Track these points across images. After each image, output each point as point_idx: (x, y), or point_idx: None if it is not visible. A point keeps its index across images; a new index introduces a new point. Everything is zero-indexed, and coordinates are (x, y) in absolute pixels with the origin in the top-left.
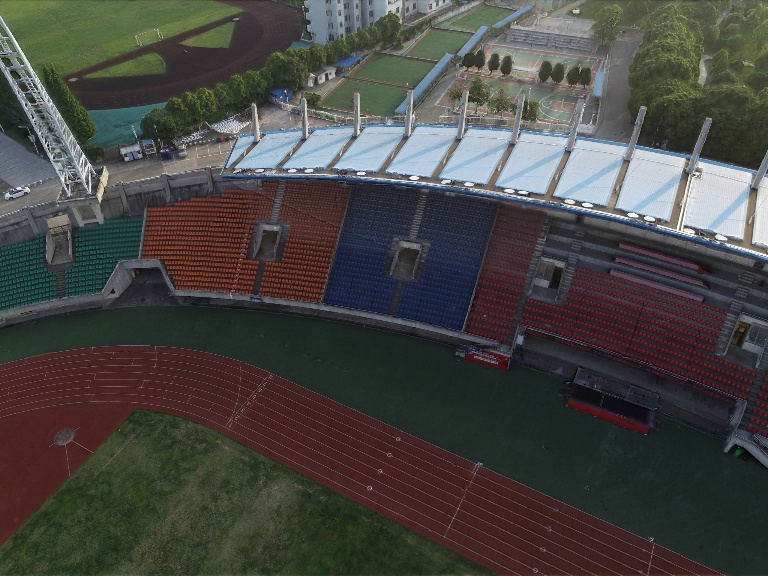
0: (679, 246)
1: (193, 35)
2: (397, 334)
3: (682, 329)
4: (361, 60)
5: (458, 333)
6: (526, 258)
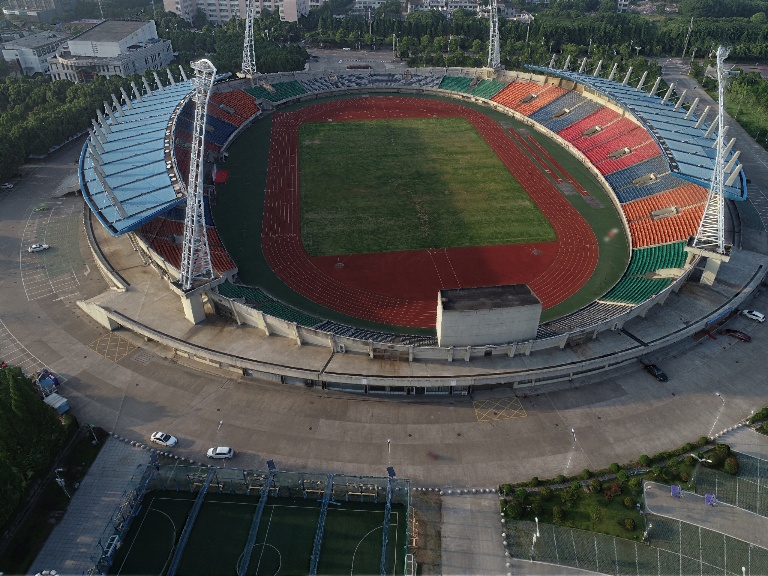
0: None
1: None
2: None
3: None
4: None
5: None
6: None
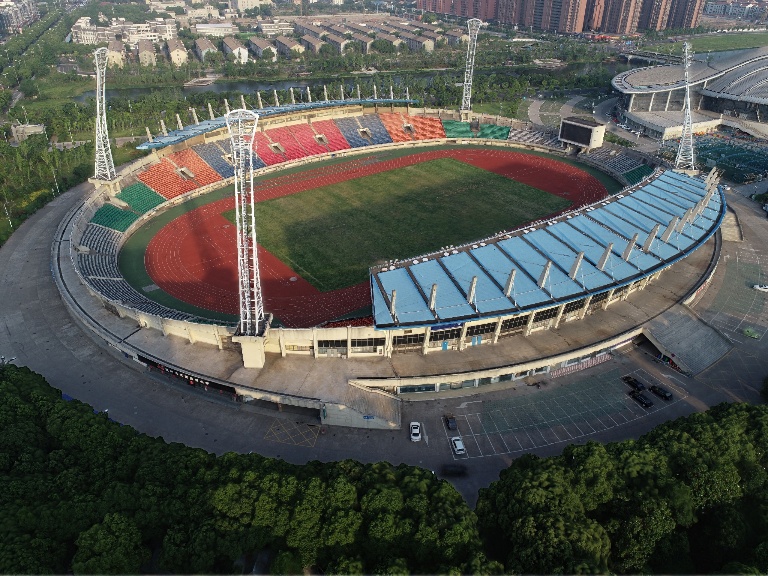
0: None
1: None
2: None
3: None
4: None
5: None
6: None
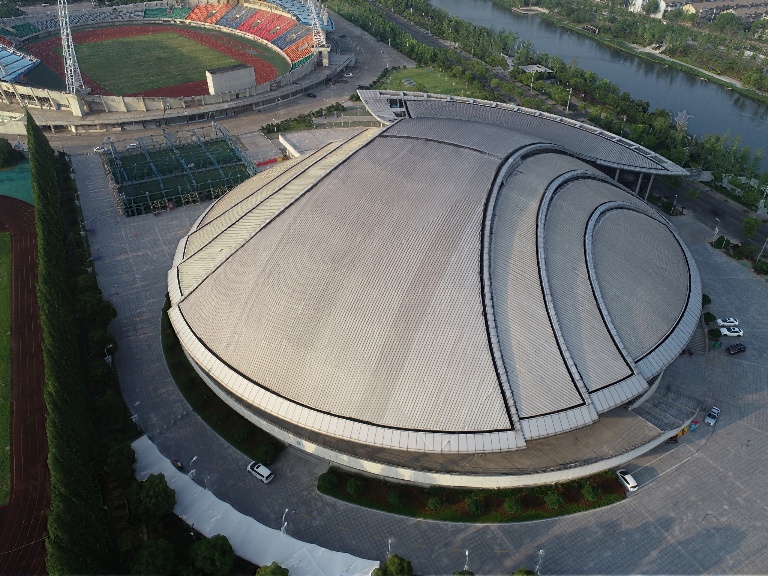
0: None
1: None
2: None
3: None
4: None
5: None
6: None
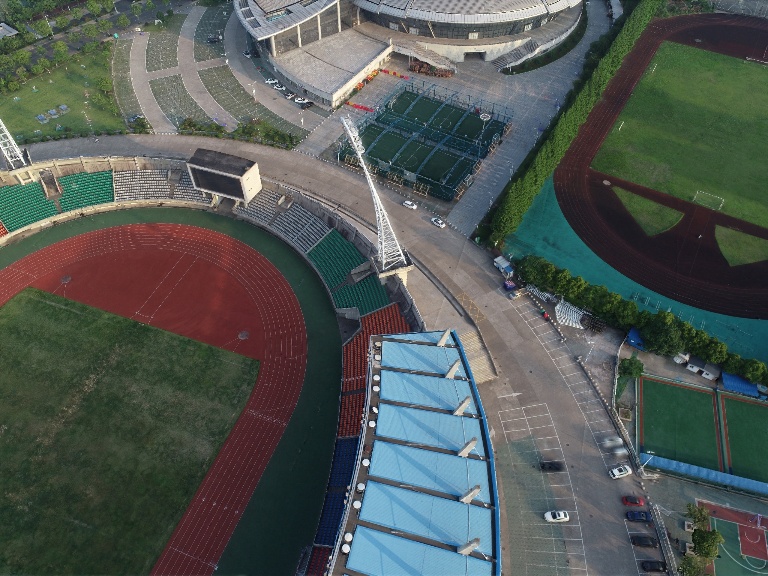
0: None
1: (742, 229)
2: None
3: None
4: (764, 399)
5: None
6: None
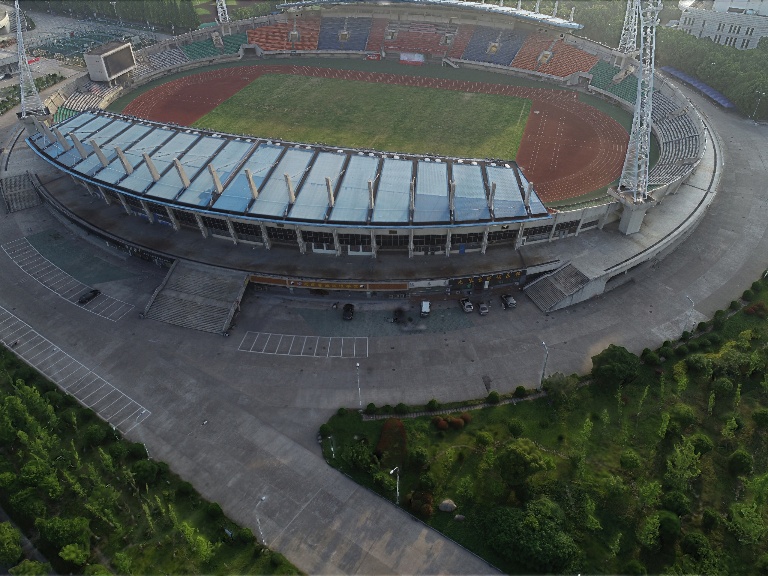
0: (429, 21)
1: None
2: (343, 58)
3: (430, 40)
4: None
5: (363, 51)
6: (383, 31)
